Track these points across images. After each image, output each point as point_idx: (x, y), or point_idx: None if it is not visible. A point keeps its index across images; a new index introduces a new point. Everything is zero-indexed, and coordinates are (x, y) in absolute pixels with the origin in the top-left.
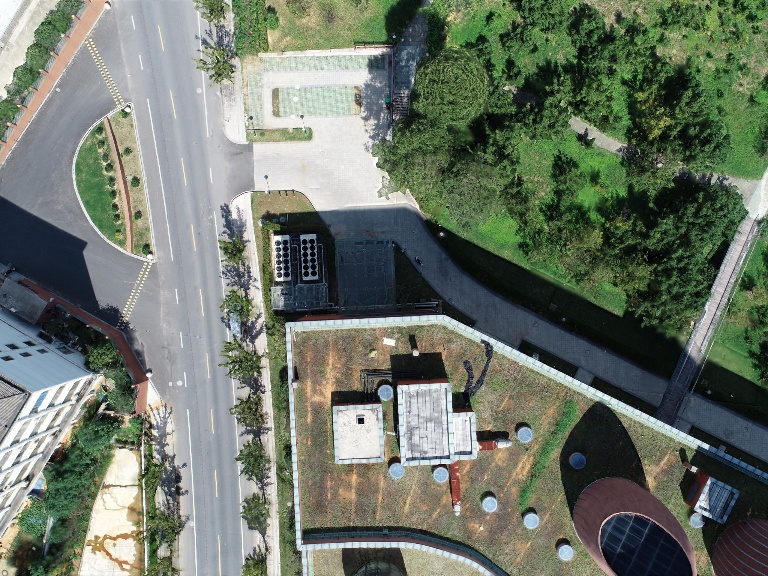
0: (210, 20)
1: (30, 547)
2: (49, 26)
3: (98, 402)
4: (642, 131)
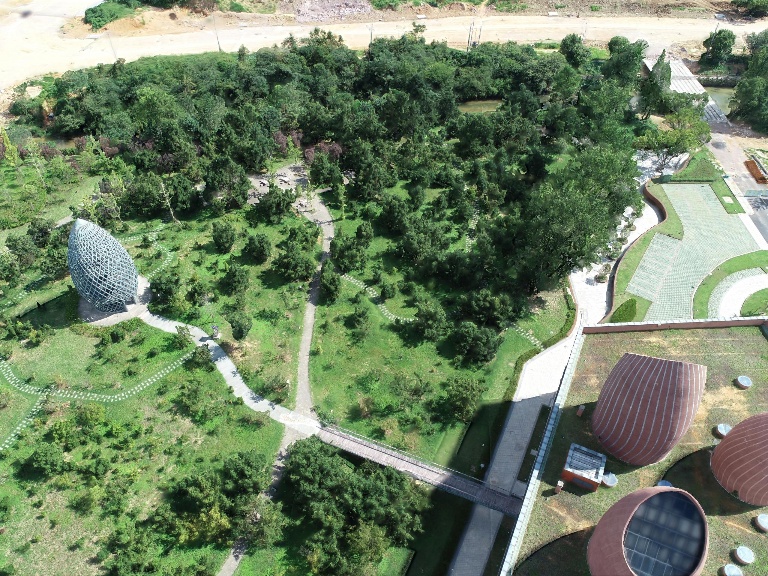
0: None
1: None
2: None
3: None
4: (221, 534)
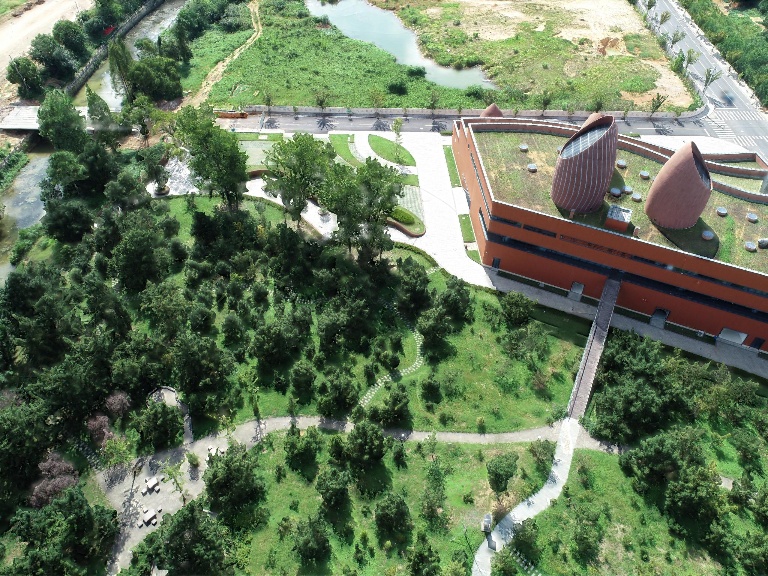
0: None
1: None
2: None
3: None
4: None
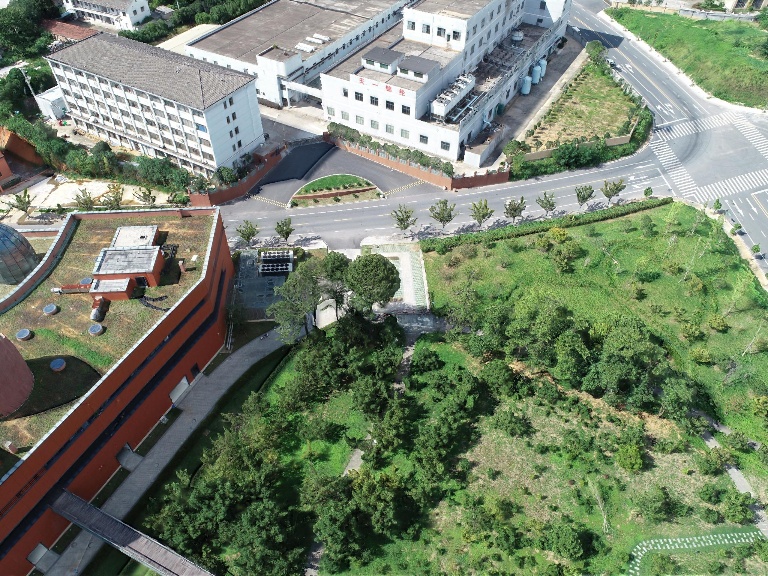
0: (431, 210)
1: (126, 160)
2: (420, 154)
3: (202, 181)
4: None
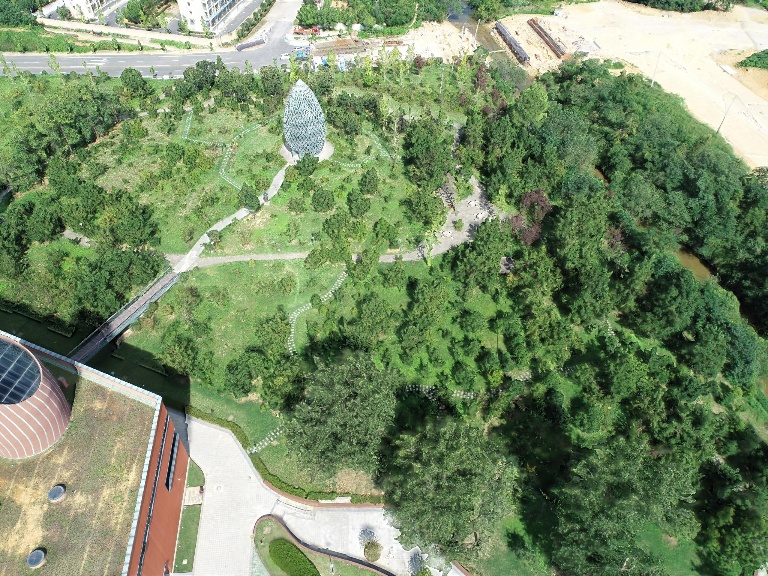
0: None
1: None
2: None
3: None
4: None
